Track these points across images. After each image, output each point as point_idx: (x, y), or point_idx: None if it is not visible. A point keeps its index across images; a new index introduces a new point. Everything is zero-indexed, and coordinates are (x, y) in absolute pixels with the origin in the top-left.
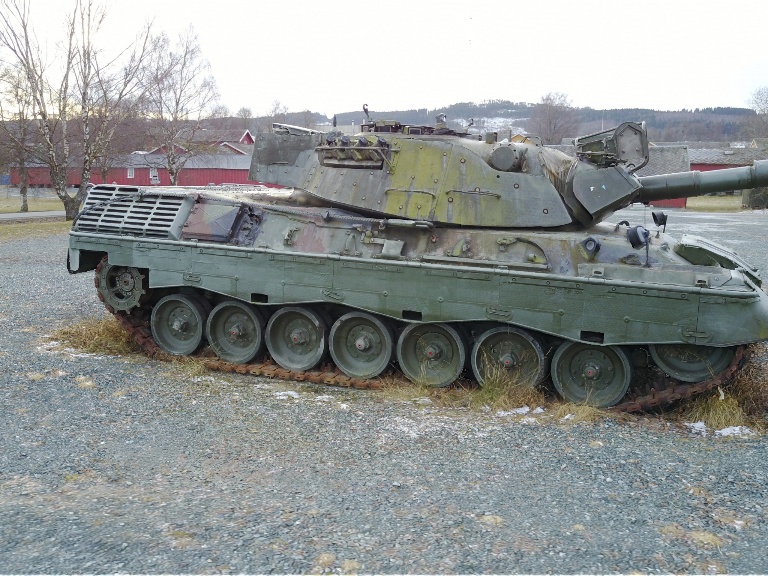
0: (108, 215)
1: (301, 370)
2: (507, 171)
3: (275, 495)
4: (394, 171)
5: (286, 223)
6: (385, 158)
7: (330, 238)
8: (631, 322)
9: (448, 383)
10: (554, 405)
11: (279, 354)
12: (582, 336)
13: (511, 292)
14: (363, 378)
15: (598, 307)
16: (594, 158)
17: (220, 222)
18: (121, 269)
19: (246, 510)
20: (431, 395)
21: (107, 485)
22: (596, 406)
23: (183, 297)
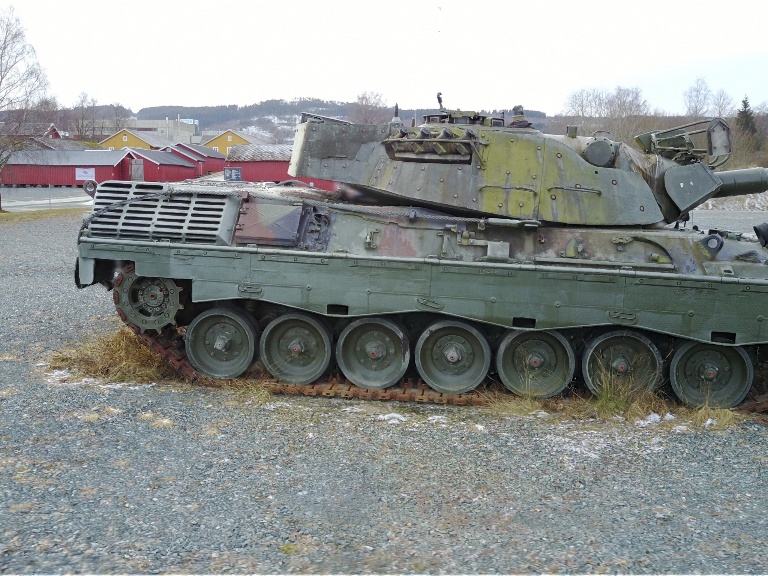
0: (129, 217)
1: (381, 388)
2: (604, 167)
3: (551, 544)
4: (485, 166)
5: (361, 224)
6: (477, 152)
7: (419, 240)
8: (765, 321)
9: (556, 393)
10: (680, 410)
11: (352, 371)
12: (712, 337)
13: (637, 294)
14: (457, 393)
15: (731, 307)
16: (666, 154)
17: (282, 224)
18: (145, 281)
19: (547, 568)
20: (544, 407)
21: (344, 553)
22: (718, 408)
23: (229, 311)
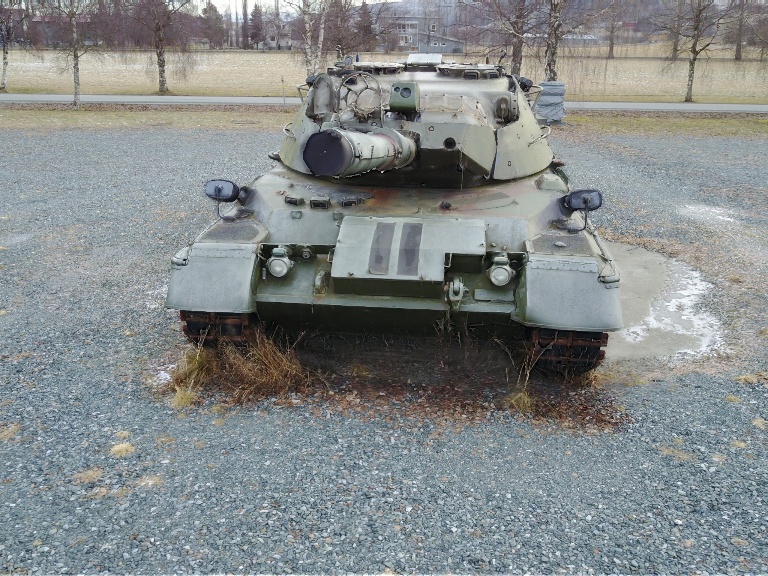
0: None
1: None
2: None
3: None
4: None
5: None
6: None
7: None
8: None
9: None
10: None
11: None
12: None
13: None
14: None
15: None
16: None
17: None
18: None
19: None
20: None
21: None
22: None
23: None
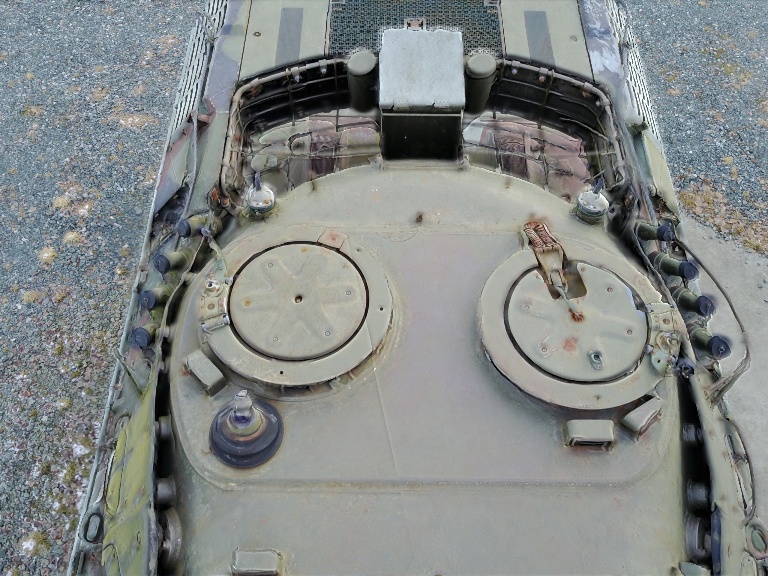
0: None
1: None
2: None
3: None
4: None
5: None
6: None
7: None
8: None
9: None
10: None
11: None
12: None
13: None
14: None
15: None
16: None
17: (166, 187)
18: None
19: None
20: None
21: None
22: None
23: None
